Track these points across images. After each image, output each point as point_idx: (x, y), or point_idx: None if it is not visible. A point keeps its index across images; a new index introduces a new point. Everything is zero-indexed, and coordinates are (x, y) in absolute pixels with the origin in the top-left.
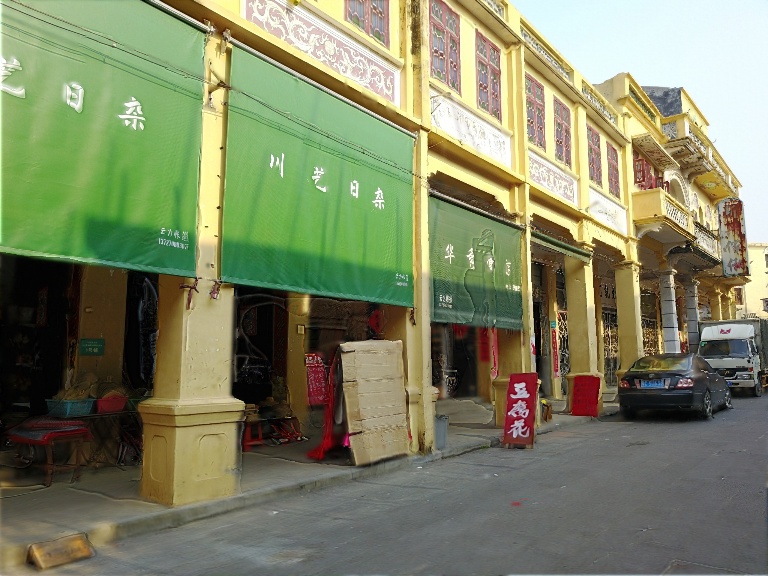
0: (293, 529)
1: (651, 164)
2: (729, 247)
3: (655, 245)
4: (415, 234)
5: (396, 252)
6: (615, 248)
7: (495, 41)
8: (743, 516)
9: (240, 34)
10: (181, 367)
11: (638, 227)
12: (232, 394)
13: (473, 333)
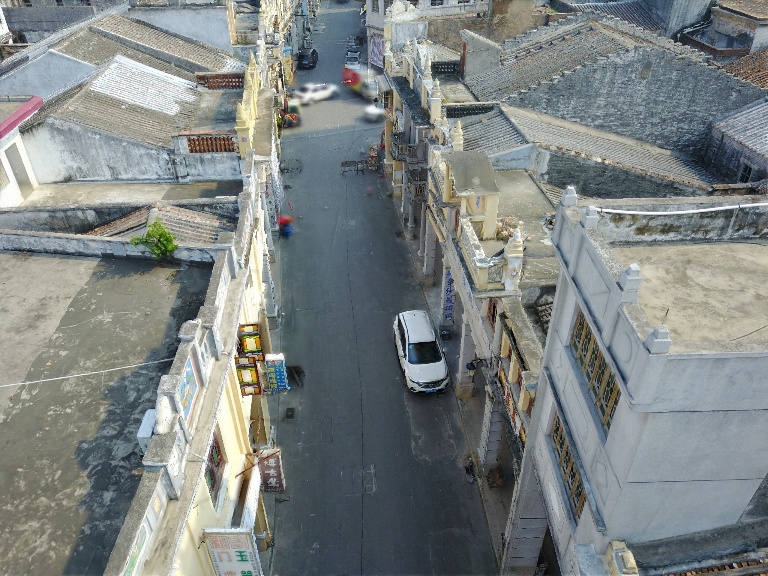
0: (327, 5)
1: None
2: None
3: None
4: None
5: None
6: None
7: None
8: (347, 1)
9: None
10: None
11: None
12: None
13: None
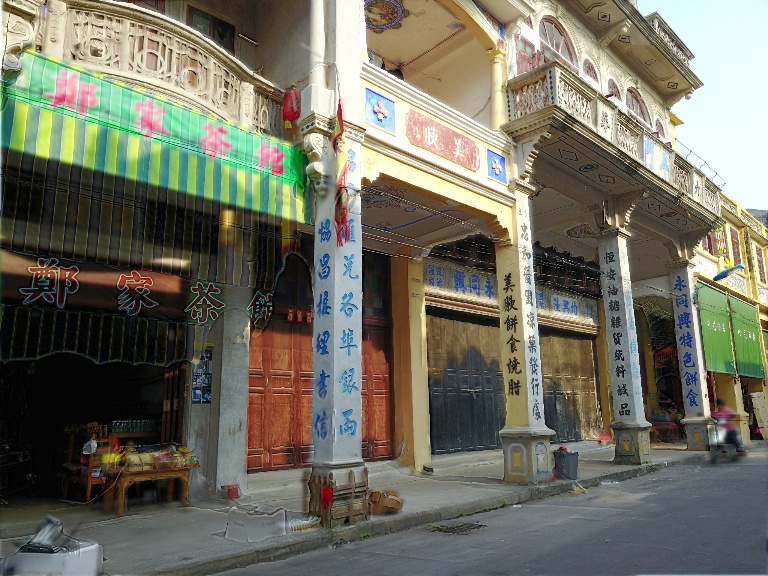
0: None
1: None
2: None
3: None
4: (761, 348)
5: (759, 357)
6: None
7: (760, 246)
8: None
9: (731, 292)
10: (736, 402)
11: None
12: (744, 411)
13: None
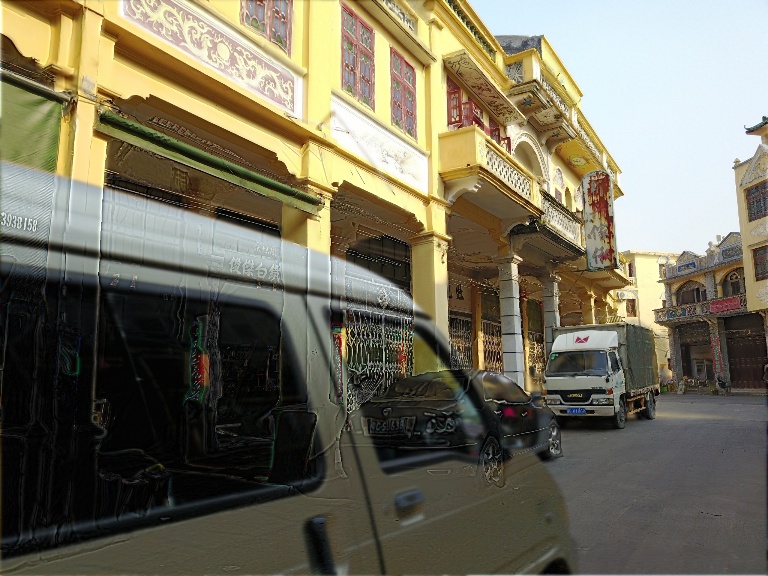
0: None
1: (484, 110)
2: (594, 233)
3: (486, 219)
4: None
5: None
6: (400, 208)
7: None
8: None
9: None
10: None
11: (448, 185)
12: None
13: (156, 336)
